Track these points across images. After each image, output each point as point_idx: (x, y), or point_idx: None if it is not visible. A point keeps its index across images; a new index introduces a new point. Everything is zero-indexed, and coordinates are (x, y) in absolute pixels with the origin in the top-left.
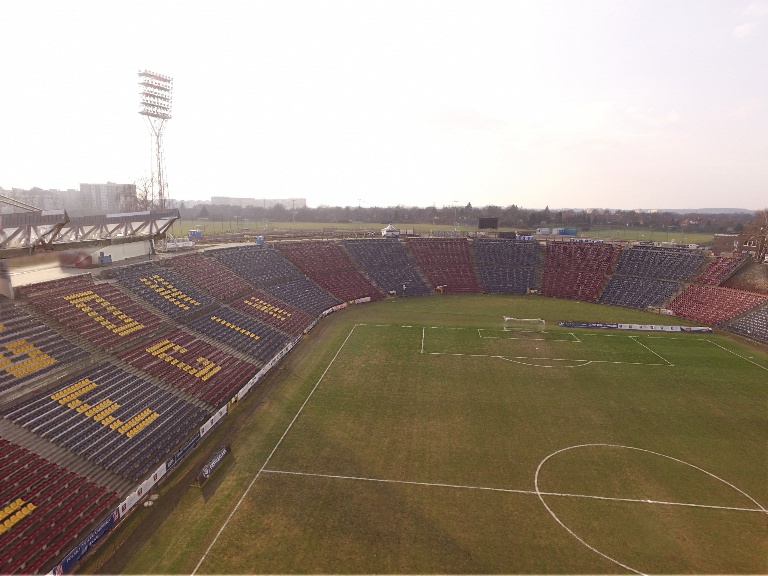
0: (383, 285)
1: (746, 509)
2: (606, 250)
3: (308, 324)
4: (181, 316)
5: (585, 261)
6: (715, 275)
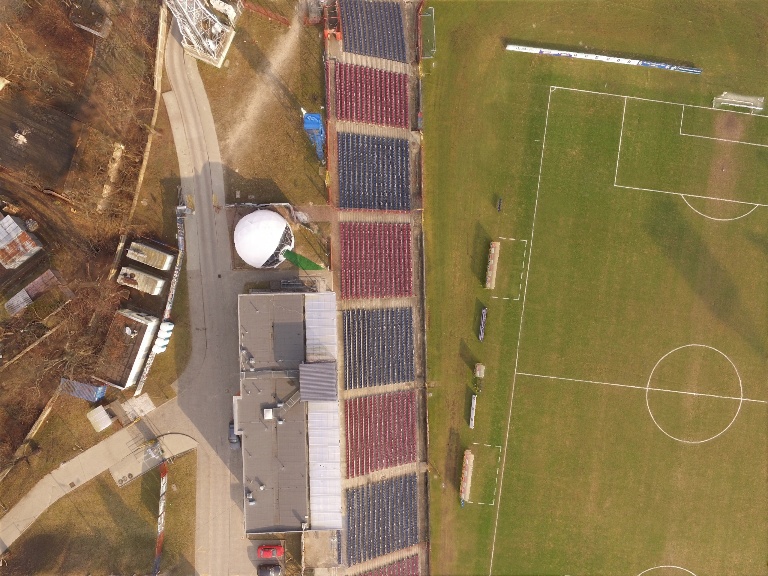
0: None
1: (655, 389)
2: None
3: None
4: None
5: None
6: None
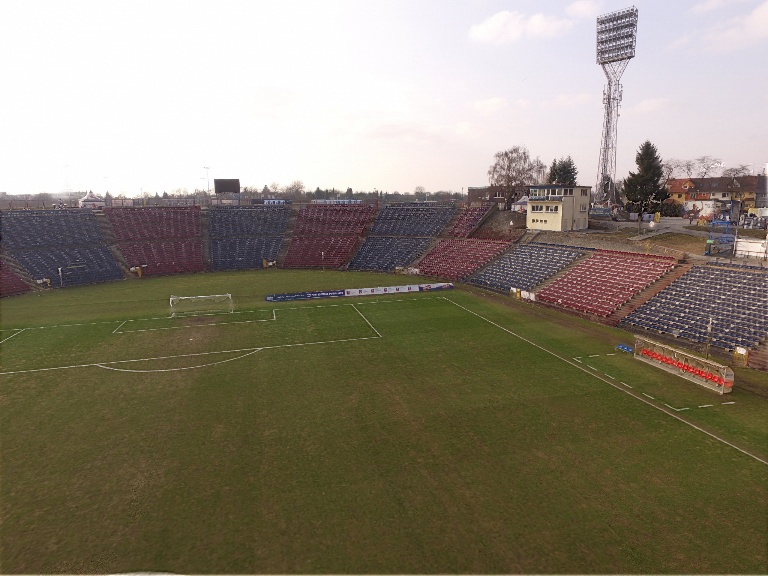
0: (38, 273)
1: None
2: (362, 210)
3: None
4: None
5: (340, 224)
6: (465, 226)
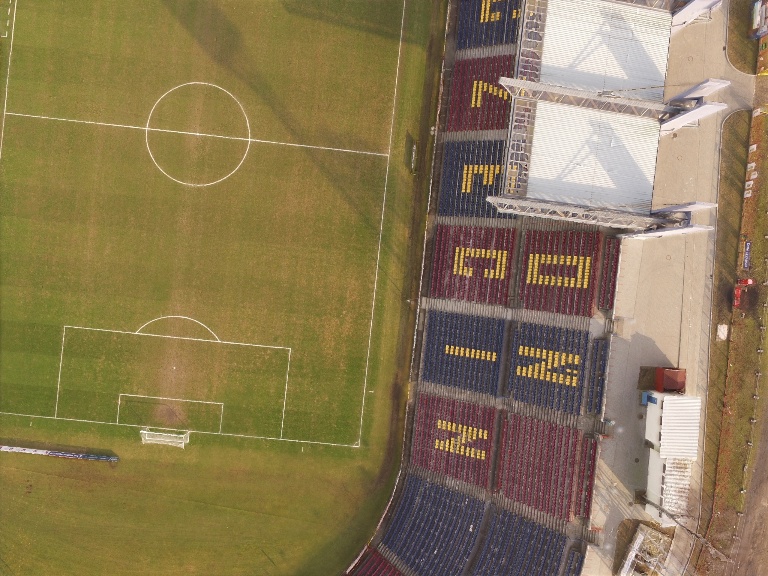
0: None
1: (155, 130)
2: None
3: (414, 440)
4: (517, 330)
5: None
6: None
